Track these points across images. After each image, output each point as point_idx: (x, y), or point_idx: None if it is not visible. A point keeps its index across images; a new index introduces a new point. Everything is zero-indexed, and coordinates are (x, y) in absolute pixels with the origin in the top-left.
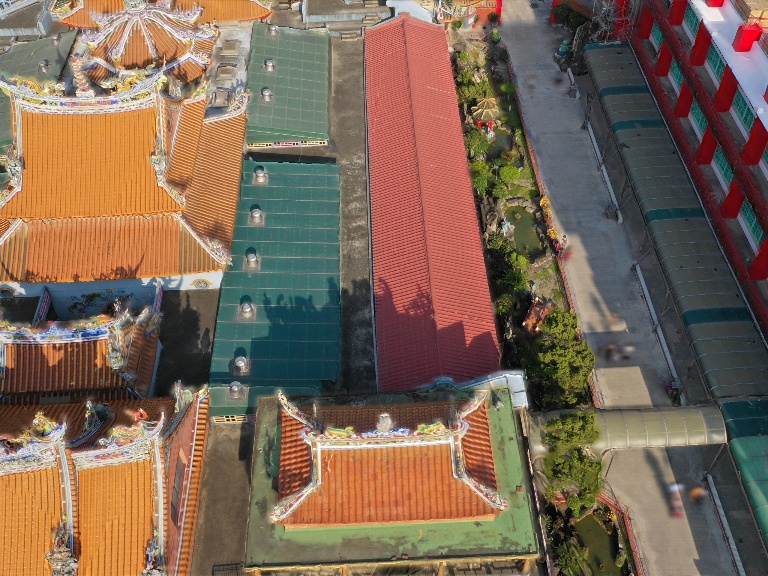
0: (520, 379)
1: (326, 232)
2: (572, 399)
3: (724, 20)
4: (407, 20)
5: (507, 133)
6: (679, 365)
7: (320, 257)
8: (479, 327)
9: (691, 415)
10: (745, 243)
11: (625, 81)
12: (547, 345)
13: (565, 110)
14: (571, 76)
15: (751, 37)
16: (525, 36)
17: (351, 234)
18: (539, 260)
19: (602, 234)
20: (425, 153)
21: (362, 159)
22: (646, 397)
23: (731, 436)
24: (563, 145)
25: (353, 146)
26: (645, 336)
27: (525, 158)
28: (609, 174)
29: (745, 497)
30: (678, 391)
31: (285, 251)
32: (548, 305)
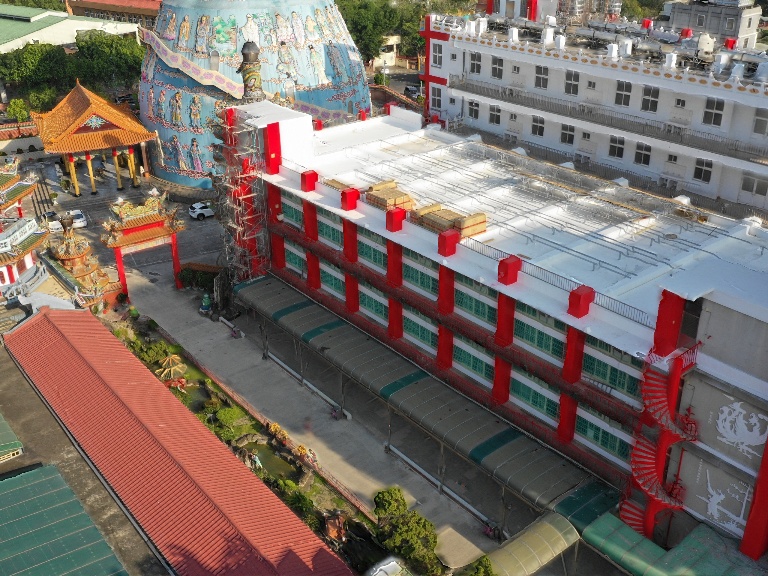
0: (396, 565)
1: (81, 534)
2: (437, 570)
3: (366, 216)
4: (49, 313)
5: (196, 387)
6: (481, 509)
7: (90, 562)
8: (310, 548)
9: (541, 528)
10: (473, 382)
11: (289, 302)
12: (387, 530)
13: (239, 350)
14: (226, 322)
15: (399, 217)
16: (161, 305)
17: (107, 528)
18: (303, 479)
19: (341, 434)
20: (146, 417)
21: (73, 452)
22: (475, 550)
23: (580, 529)
24: (256, 378)
25: (54, 444)
26: (437, 500)
27: (229, 401)
28: (314, 385)
29: (627, 573)
30: (498, 529)
31: (42, 575)
32: (337, 514)
